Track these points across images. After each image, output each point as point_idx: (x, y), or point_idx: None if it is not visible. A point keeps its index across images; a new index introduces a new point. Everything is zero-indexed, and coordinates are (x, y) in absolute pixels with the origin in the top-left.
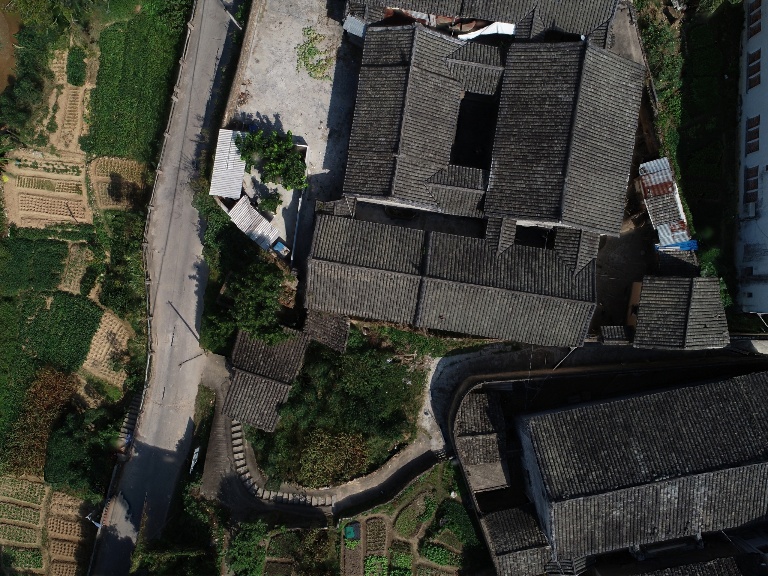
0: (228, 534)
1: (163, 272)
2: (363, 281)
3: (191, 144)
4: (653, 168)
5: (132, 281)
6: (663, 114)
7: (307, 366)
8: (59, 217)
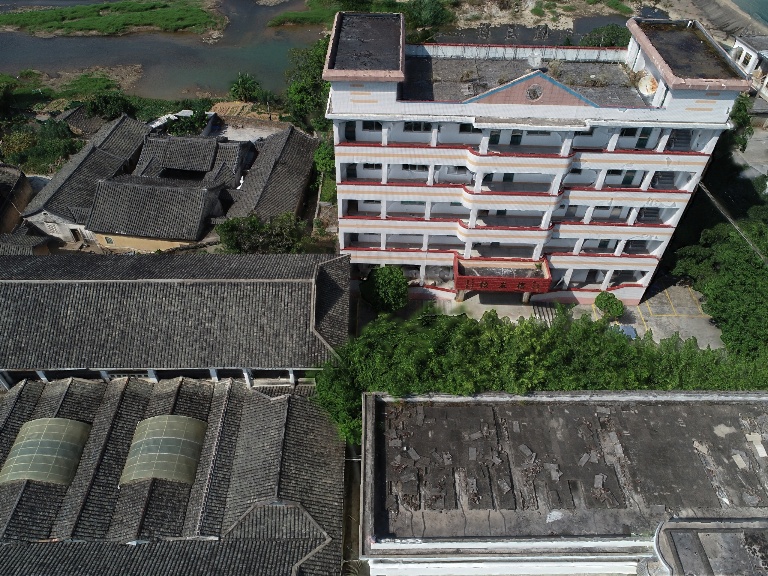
0: (1, 127)
1: None
2: None
3: None
4: None
5: None
6: None
7: None
8: None
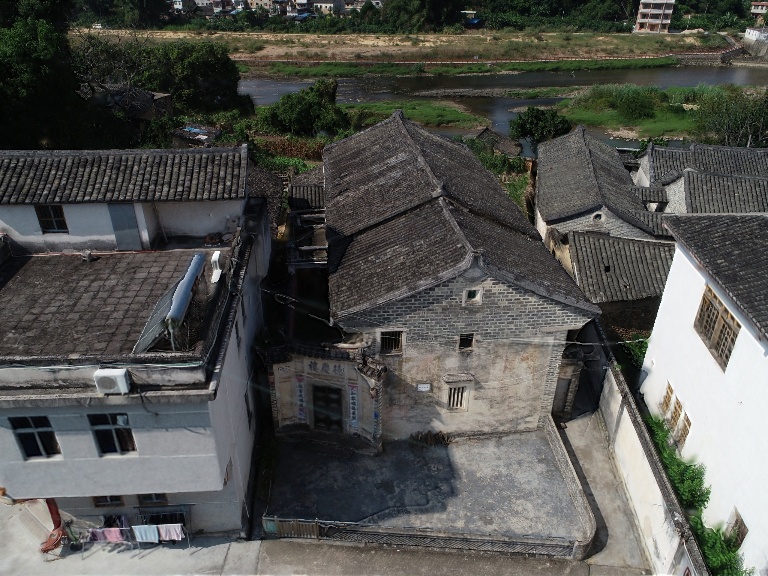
0: None
1: None
2: None
3: None
4: None
5: None
6: None
7: None
8: None
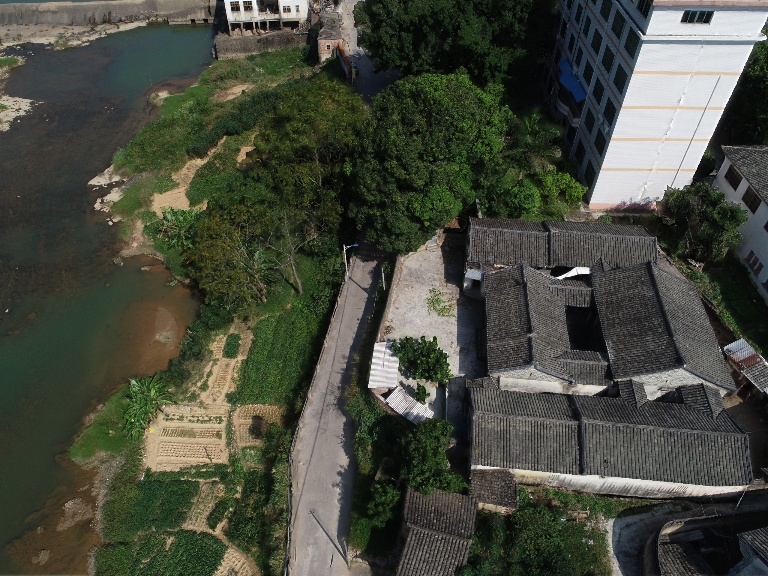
0: None
1: (307, 483)
2: (525, 431)
3: (337, 375)
4: (735, 348)
5: (274, 495)
6: None
7: (479, 530)
8: (195, 460)
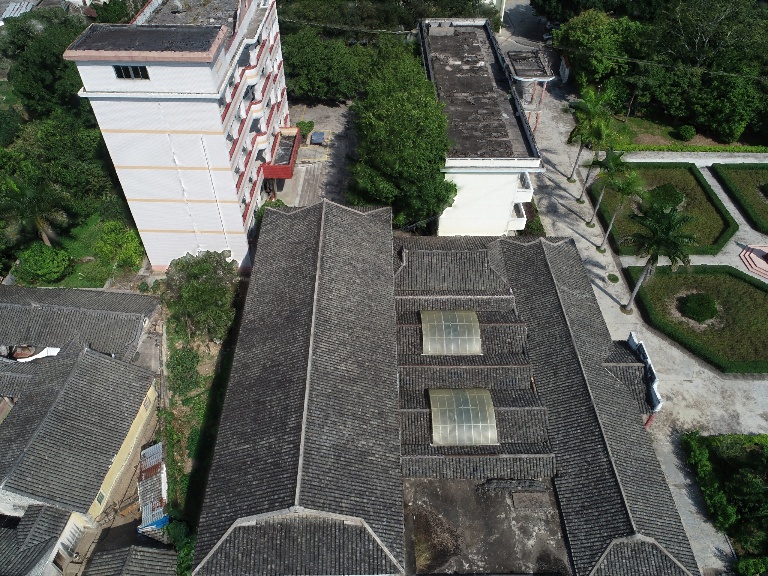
0: None
1: None
2: None
3: None
4: (150, 453)
5: None
6: (189, 416)
7: None
8: None
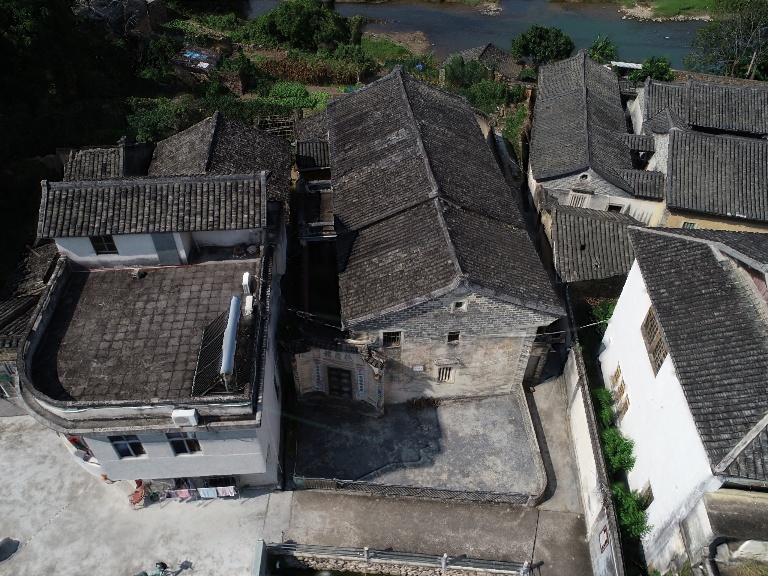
0: None
1: None
2: None
3: None
4: None
5: None
6: None
7: None
8: None
